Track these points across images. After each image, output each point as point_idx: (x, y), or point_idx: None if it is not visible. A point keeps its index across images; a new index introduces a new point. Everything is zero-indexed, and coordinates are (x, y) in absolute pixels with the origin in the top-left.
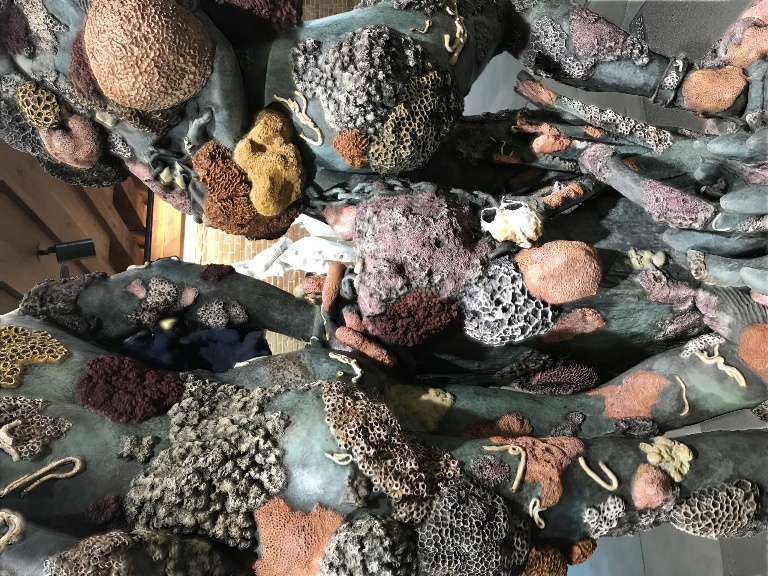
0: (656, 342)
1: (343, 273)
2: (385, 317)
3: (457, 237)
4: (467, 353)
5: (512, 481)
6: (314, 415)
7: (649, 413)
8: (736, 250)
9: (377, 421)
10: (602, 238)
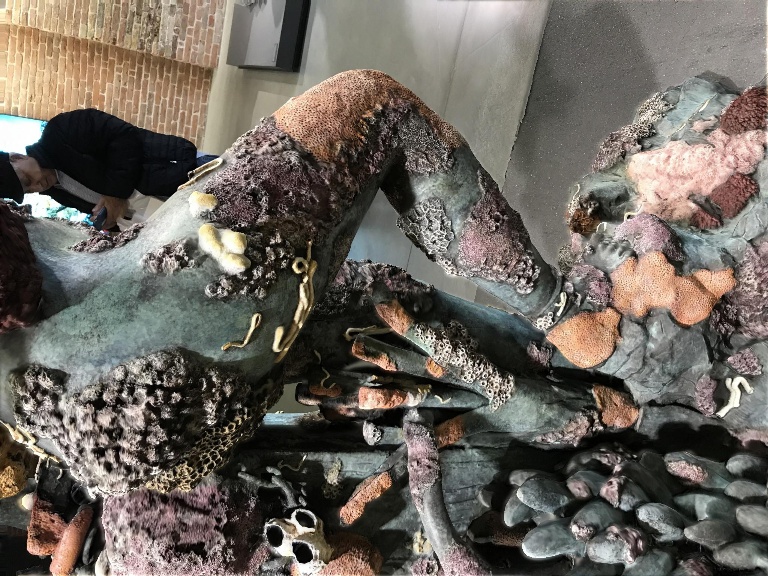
0: None
1: (82, 547)
2: None
3: (229, 568)
4: None
5: None
6: None
7: None
8: None
9: None
10: (395, 516)
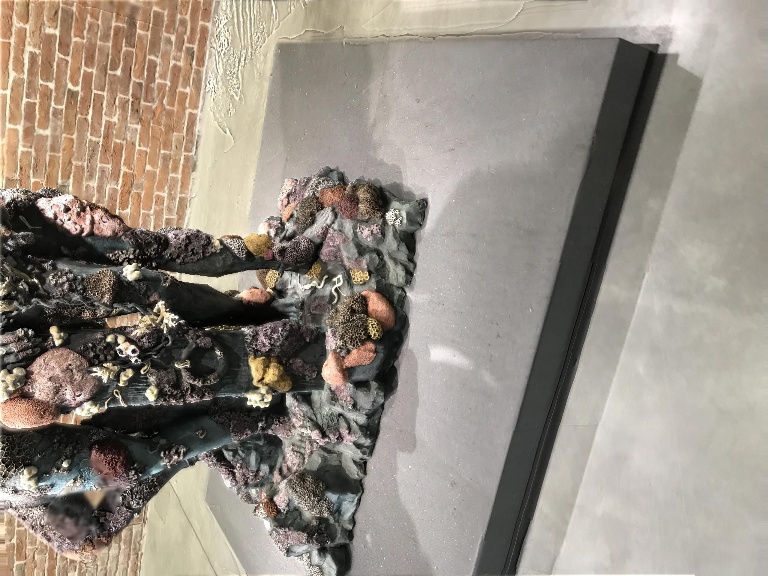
0: None
1: None
2: None
3: None
4: None
5: None
6: None
7: None
8: None
9: None
10: None
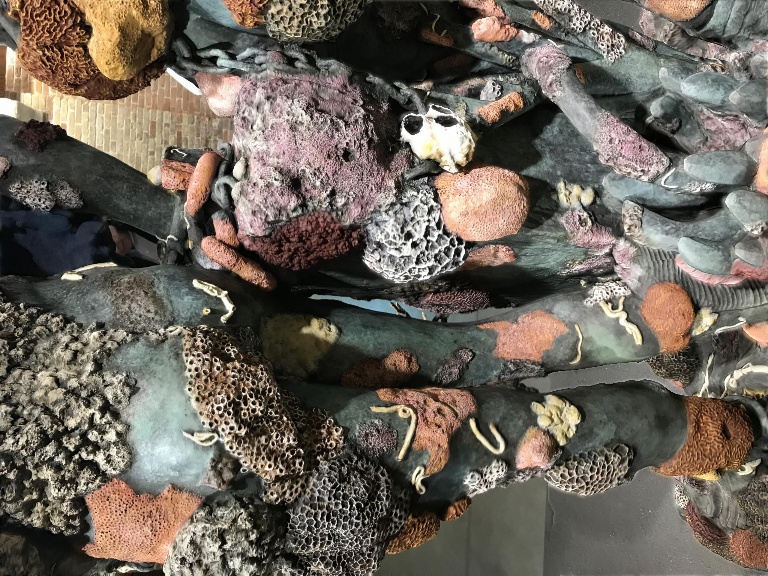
0: (557, 276)
1: (217, 170)
2: (269, 239)
3: (371, 150)
4: (357, 273)
5: (399, 449)
6: (171, 381)
7: (540, 358)
8: (672, 204)
9: (252, 392)
10: (532, 163)
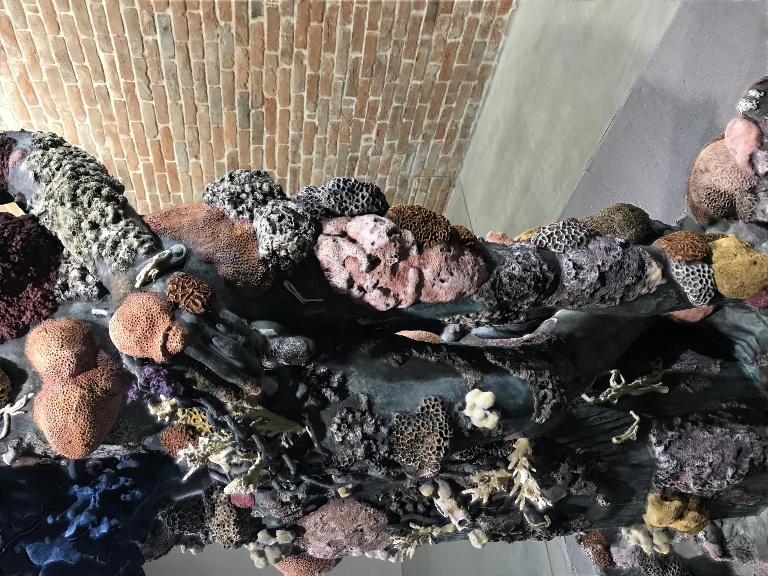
0: None
1: None
2: None
3: None
4: None
5: None
6: None
7: None
8: (524, 324)
9: None
10: None
